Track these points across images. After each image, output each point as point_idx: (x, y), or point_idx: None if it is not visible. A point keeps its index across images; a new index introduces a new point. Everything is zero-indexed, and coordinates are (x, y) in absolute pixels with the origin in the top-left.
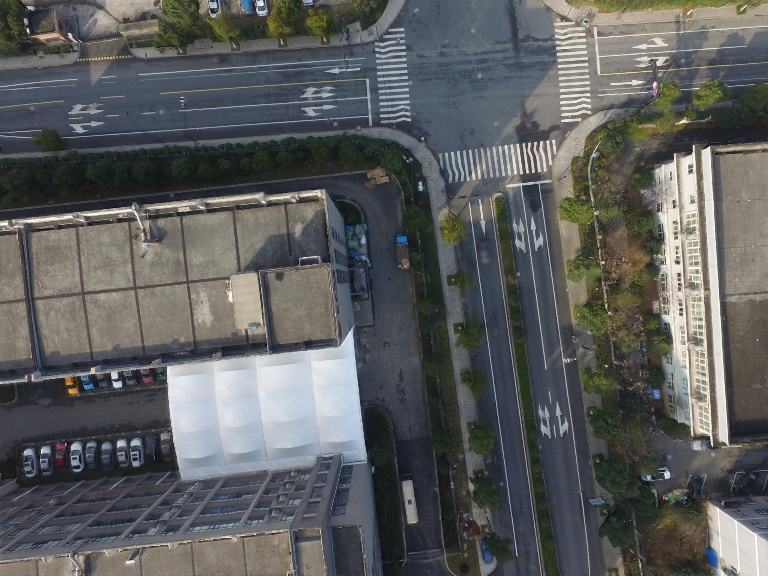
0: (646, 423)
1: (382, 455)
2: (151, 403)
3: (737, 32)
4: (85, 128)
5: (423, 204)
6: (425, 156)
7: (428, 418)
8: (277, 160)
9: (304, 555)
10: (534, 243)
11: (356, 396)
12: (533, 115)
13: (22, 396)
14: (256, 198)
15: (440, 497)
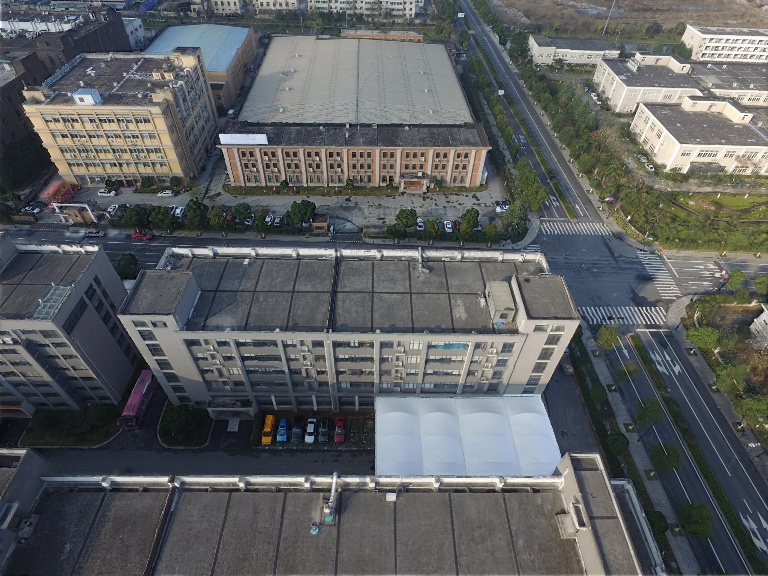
0: None
1: None
2: (336, 463)
3: (761, 266)
4: None
5: None
6: None
7: None
8: None
9: (586, 483)
10: (673, 369)
11: (557, 450)
12: (640, 293)
13: (212, 443)
14: (495, 257)
15: None
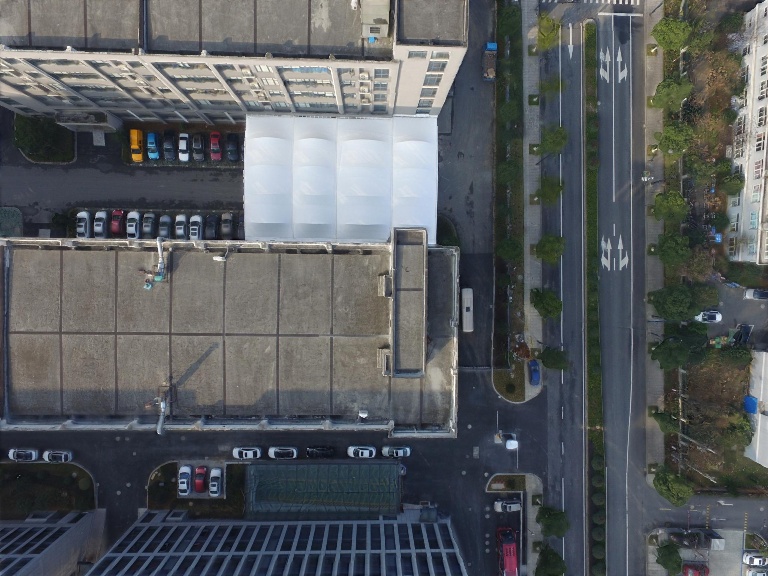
0: None
1: None
2: (215, 183)
3: None
4: None
5: None
6: None
7: (493, 234)
8: None
9: (404, 258)
10: (618, 74)
11: (435, 183)
12: None
13: (81, 158)
14: None
15: (495, 314)
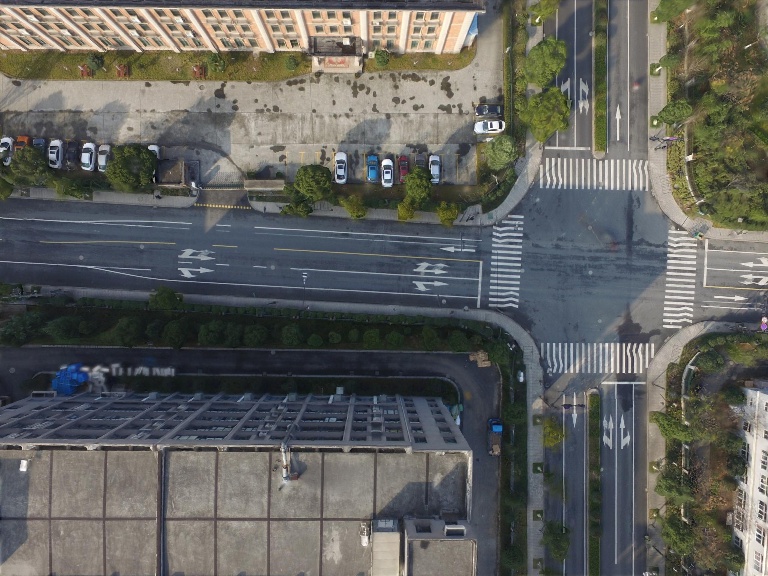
0: None
1: None
2: None
3: None
4: (193, 273)
5: (520, 392)
6: (527, 344)
7: None
8: (388, 340)
9: None
10: (621, 441)
11: None
12: (636, 317)
13: None
14: None
15: None
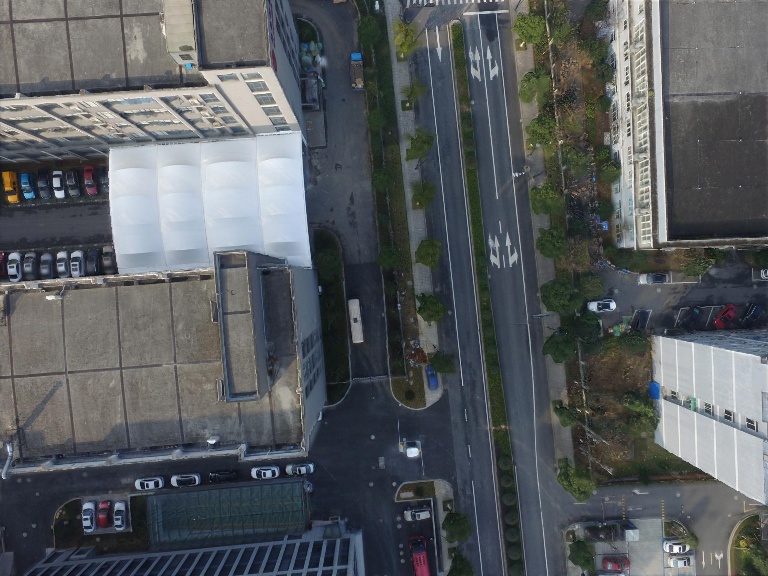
0: (594, 256)
1: (327, 261)
2: (94, 217)
3: None
4: None
5: (379, 26)
6: None
7: (378, 243)
8: None
9: (228, 281)
10: (489, 72)
11: (302, 198)
12: None
13: None
14: None
15: (387, 322)
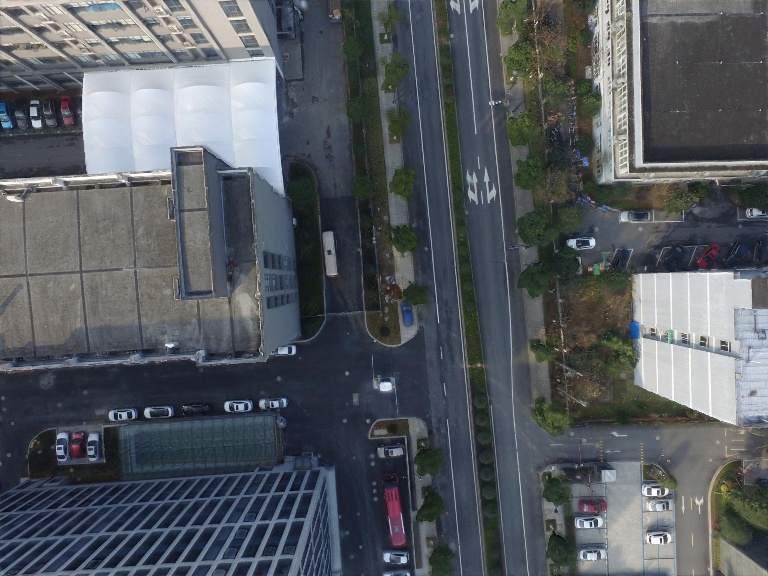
0: None
1: (299, 188)
2: (71, 147)
3: None
4: None
5: None
6: None
7: (354, 177)
8: None
9: (185, 178)
10: (469, 5)
11: (274, 123)
12: None
13: None
14: None
15: (362, 257)
